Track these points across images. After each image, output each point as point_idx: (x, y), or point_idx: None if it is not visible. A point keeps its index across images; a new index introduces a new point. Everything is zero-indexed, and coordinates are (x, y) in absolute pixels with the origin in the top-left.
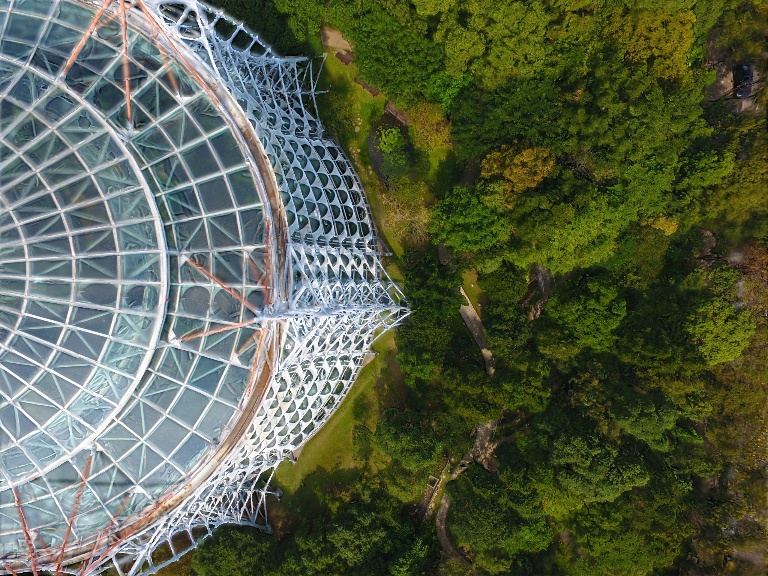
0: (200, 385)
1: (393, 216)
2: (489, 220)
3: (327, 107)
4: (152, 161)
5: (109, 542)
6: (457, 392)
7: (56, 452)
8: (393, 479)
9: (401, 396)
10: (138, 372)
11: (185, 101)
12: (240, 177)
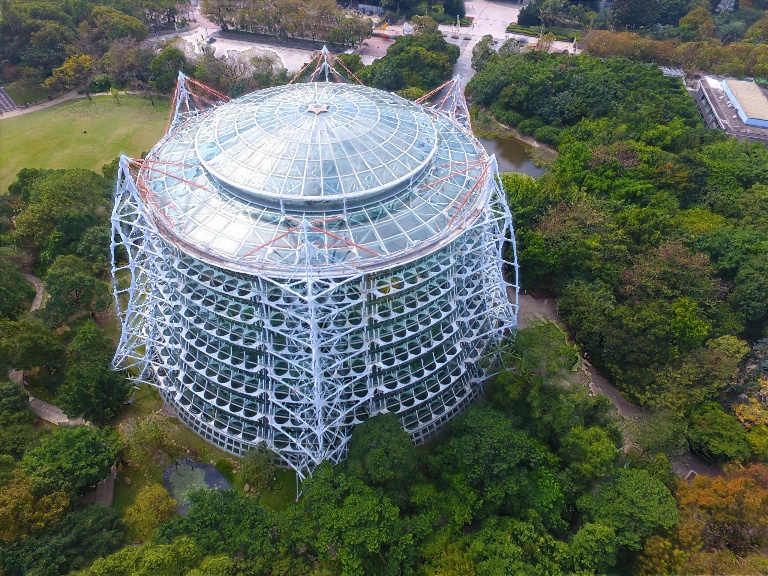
0: (177, 166)
1: (156, 415)
2: (44, 460)
3: (288, 486)
4: (264, 215)
5: None
6: None
7: None
8: (75, 260)
9: None
10: (197, 139)
11: (270, 250)
12: (211, 242)
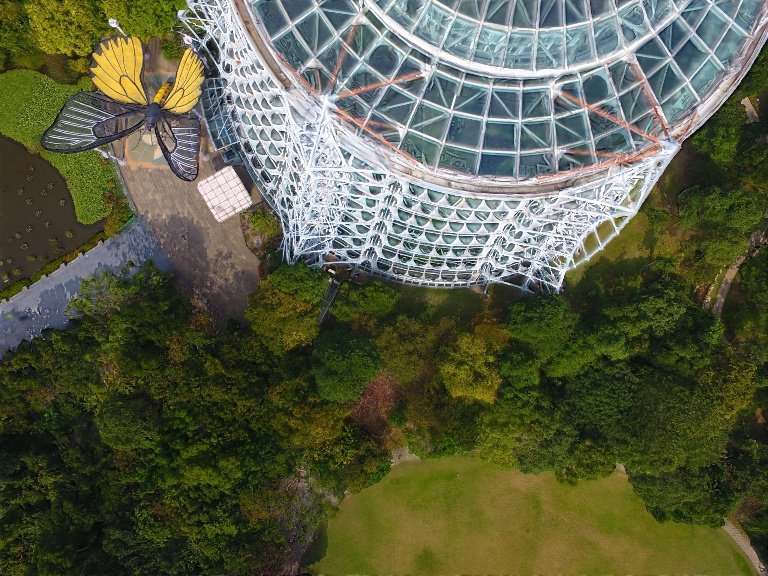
0: None
1: None
2: None
3: None
4: None
5: (622, 169)
6: (766, 164)
7: (637, 33)
8: (722, 236)
9: (683, 188)
10: None
11: None
12: None
